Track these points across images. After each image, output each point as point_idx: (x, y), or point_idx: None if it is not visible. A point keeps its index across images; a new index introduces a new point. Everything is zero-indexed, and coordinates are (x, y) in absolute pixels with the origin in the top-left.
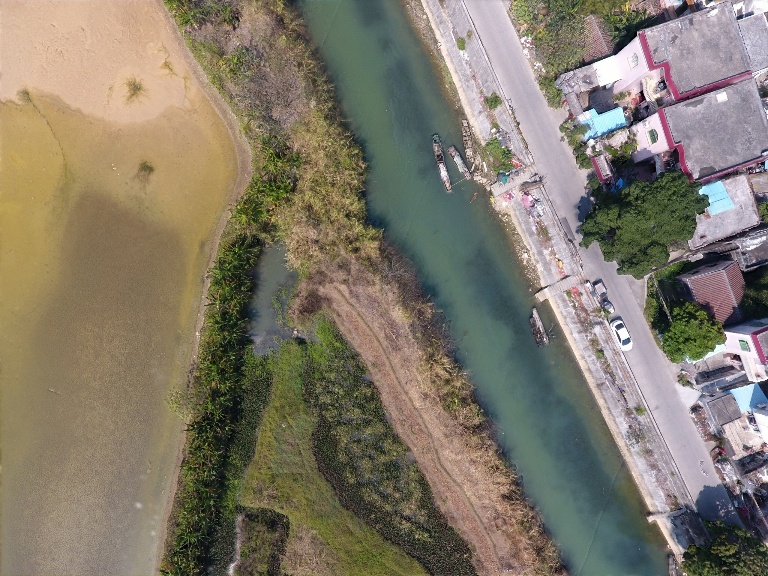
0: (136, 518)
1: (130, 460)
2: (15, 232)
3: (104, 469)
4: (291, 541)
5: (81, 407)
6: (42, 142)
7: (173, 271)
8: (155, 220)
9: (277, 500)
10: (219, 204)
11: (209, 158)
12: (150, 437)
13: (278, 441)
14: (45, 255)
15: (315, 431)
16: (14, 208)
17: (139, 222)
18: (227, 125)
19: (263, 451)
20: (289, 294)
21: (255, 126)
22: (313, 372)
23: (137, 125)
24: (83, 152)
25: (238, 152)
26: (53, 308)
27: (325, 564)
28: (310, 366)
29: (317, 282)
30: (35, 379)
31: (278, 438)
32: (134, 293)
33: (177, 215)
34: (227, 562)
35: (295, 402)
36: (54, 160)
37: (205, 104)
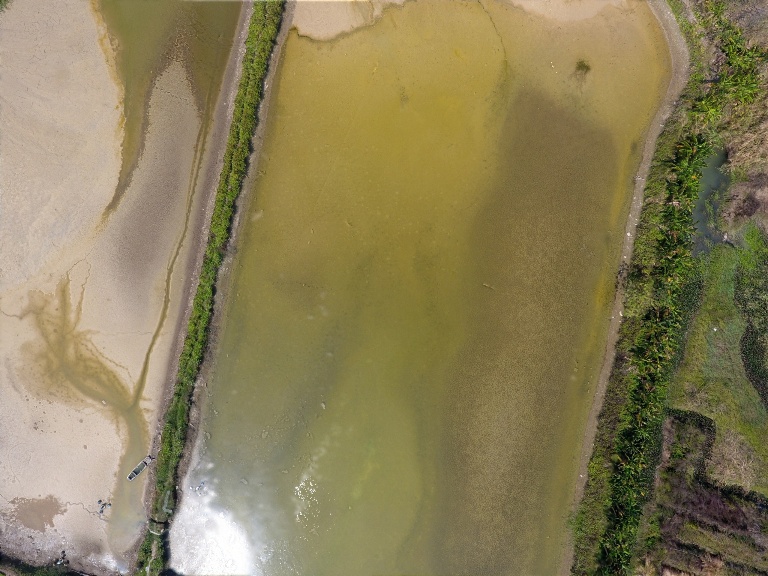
0: (562, 416)
1: (558, 358)
2: (456, 127)
3: (533, 366)
4: (718, 445)
5: (514, 303)
6: (485, 38)
7: (605, 171)
8: (590, 119)
9: (707, 403)
10: (652, 105)
11: (644, 59)
12: (578, 336)
13: (710, 344)
14: (484, 151)
15: (743, 337)
16: (456, 103)
17: (575, 121)
18: (663, 26)
19: (696, 354)
20: (722, 198)
21: (715, 22)
22: (742, 277)
23: (576, 23)
24: (523, 49)
25: (673, 53)
26: (490, 204)
27: (752, 470)
28: (739, 271)
29: (759, 184)
30: (471, 273)
31: (710, 341)
32: (567, 192)
33: (611, 115)
34: (654, 463)
35: (727, 306)
36: (496, 56)
37: (642, 4)
